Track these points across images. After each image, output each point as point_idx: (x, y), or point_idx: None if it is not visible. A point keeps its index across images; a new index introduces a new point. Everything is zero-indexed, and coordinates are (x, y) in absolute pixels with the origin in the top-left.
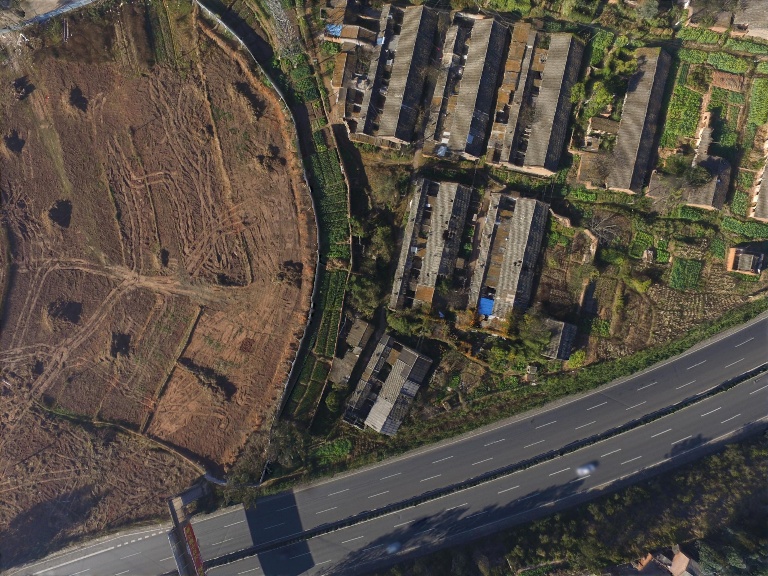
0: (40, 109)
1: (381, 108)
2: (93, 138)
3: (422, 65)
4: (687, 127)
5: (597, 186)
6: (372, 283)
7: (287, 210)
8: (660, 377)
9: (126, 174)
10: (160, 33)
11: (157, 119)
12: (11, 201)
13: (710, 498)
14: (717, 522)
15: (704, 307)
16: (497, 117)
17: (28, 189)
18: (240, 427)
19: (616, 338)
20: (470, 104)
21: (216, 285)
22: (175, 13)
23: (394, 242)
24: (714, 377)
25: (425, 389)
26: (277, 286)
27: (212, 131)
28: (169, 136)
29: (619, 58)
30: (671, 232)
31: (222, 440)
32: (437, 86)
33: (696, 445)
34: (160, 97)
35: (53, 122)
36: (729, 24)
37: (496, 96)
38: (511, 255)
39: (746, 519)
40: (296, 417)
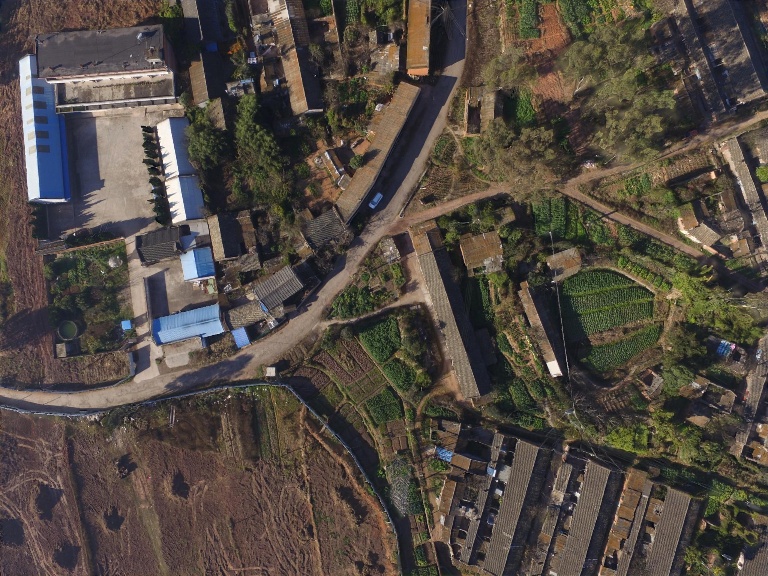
0: (141, 488)
1: (487, 536)
2: (192, 523)
3: (532, 502)
4: None
5: None
6: None
7: None
8: None
9: (223, 564)
10: (266, 429)
11: (258, 514)
12: (107, 575)
13: None
14: None
15: None
16: None
17: (124, 565)
18: None
19: None
20: (580, 552)
21: None
22: (282, 410)
23: None
24: None
25: None
26: None
27: (312, 532)
28: (269, 533)
29: None
30: None
31: None
32: (546, 523)
33: None
34: (262, 492)
35: (153, 503)
36: None
37: (606, 540)
38: None
39: None
40: None
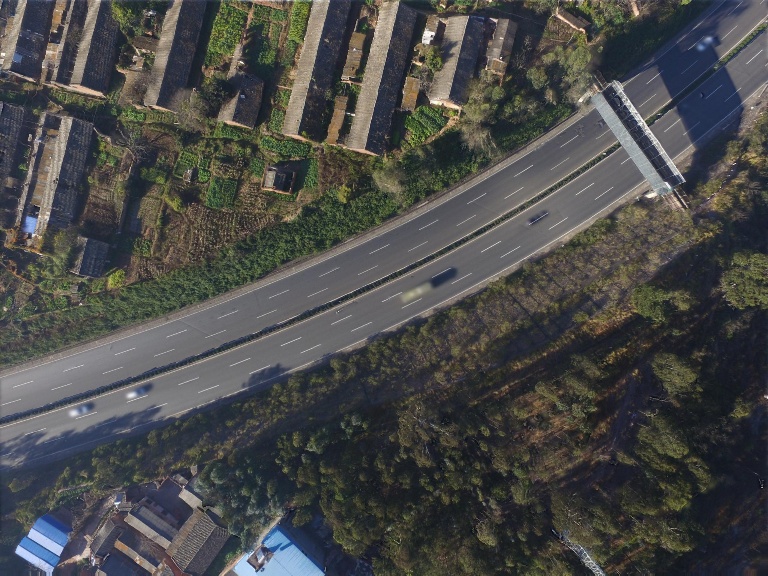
0: None
1: None
2: None
3: None
4: (228, 45)
5: (138, 104)
6: None
7: None
8: (241, 306)
9: None
10: None
11: None
12: None
13: (253, 423)
14: (243, 445)
15: (236, 226)
16: (54, 38)
17: None
18: None
19: (155, 258)
20: (19, 24)
21: None
22: None
23: None
24: (295, 306)
25: None
26: None
27: None
28: None
29: None
30: (212, 151)
31: None
32: None
33: (273, 375)
34: None
35: None
36: None
37: (51, 17)
38: (52, 173)
39: (268, 442)
40: None
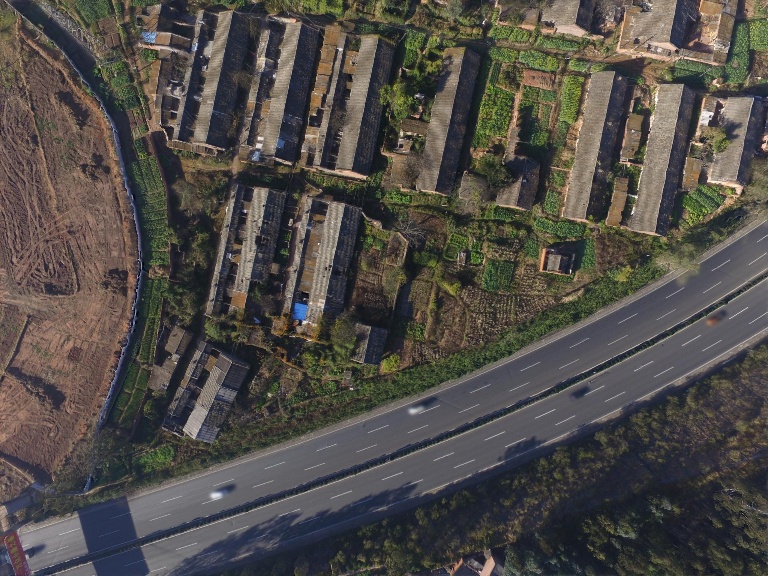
0: None
1: (198, 114)
2: None
3: (235, 70)
4: (498, 127)
5: (408, 188)
6: (185, 290)
7: (112, 218)
8: (493, 379)
9: None
10: None
11: None
12: None
13: (531, 502)
14: (532, 526)
15: (516, 309)
16: (311, 121)
17: None
18: (69, 435)
19: (430, 341)
20: (280, 108)
21: (43, 294)
22: None
23: (214, 248)
24: (548, 379)
25: (245, 395)
26: (103, 294)
27: (37, 141)
28: None
29: (431, 59)
30: (484, 233)
31: (52, 449)
32: (251, 91)
33: (530, 448)
34: None
35: None
36: (536, 22)
37: (309, 100)
38: (323, 260)
39: (560, 523)
40: (121, 425)
